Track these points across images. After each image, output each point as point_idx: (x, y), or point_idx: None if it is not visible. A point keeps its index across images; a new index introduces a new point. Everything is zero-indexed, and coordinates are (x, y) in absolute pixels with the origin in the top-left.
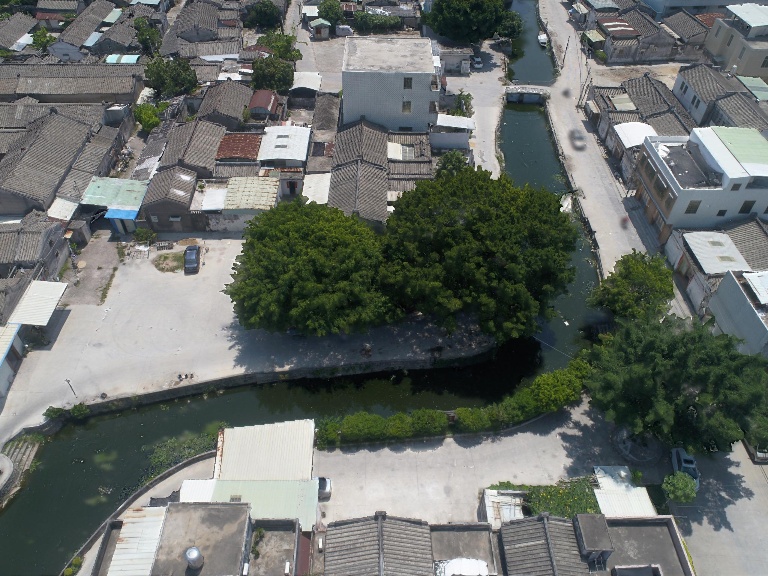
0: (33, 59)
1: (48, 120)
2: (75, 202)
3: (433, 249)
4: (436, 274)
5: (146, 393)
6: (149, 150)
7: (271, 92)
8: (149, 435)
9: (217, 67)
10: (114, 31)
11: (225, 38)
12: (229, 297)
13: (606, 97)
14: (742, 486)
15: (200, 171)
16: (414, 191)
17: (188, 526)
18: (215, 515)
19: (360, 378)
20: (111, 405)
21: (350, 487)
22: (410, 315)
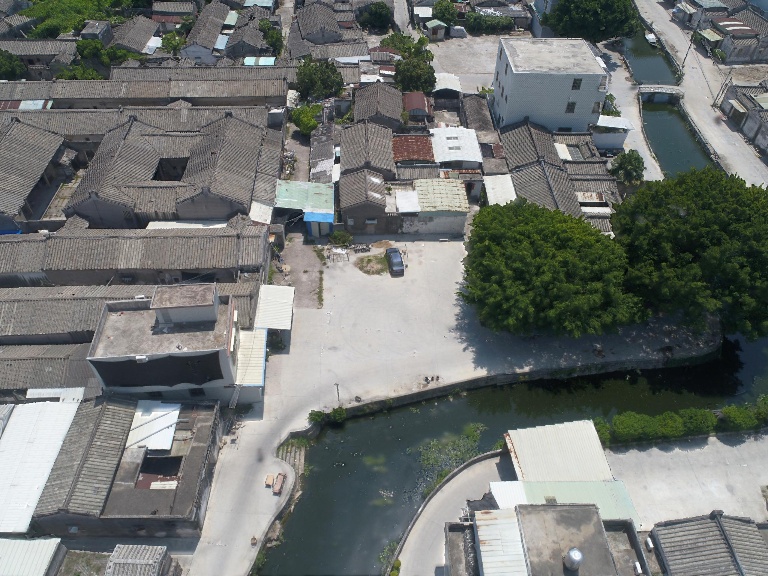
0: (170, 62)
1: (227, 124)
2: (270, 206)
3: (681, 249)
4: (695, 274)
5: (398, 396)
6: (318, 153)
7: (422, 94)
8: (408, 438)
9: (359, 69)
10: (245, 33)
11: (349, 40)
12: (444, 299)
13: (748, 96)
14: None
15: (384, 173)
16: (650, 192)
17: (546, 528)
18: (567, 516)
19: (596, 378)
20: (366, 408)
21: (634, 487)
22: None
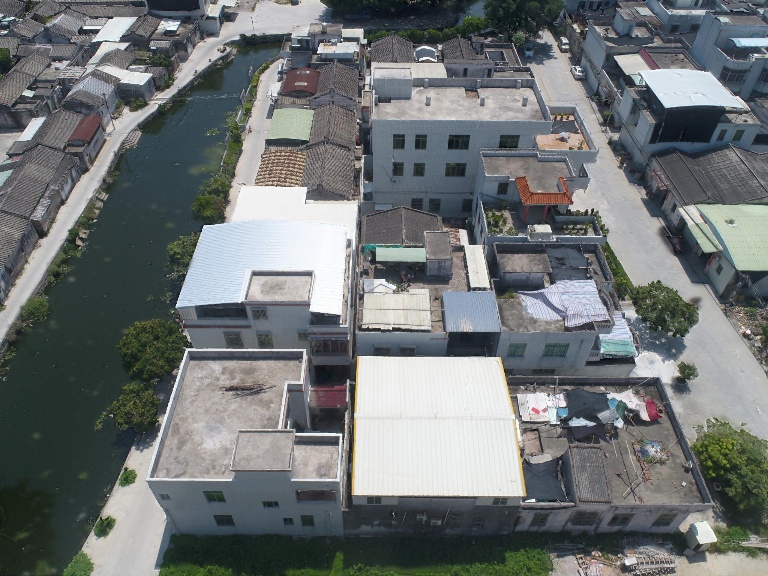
0: None
1: None
2: None
3: None
4: None
5: (283, 34)
6: None
7: None
8: None
9: None
10: None
11: None
12: (316, 11)
13: None
14: (553, 57)
15: None
16: None
17: (319, 27)
18: None
19: None
20: (267, 38)
21: None
22: (407, 17)
